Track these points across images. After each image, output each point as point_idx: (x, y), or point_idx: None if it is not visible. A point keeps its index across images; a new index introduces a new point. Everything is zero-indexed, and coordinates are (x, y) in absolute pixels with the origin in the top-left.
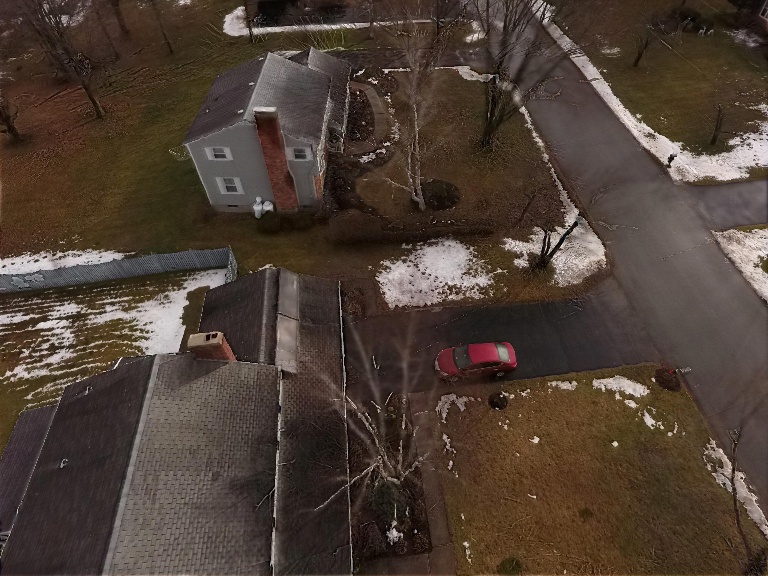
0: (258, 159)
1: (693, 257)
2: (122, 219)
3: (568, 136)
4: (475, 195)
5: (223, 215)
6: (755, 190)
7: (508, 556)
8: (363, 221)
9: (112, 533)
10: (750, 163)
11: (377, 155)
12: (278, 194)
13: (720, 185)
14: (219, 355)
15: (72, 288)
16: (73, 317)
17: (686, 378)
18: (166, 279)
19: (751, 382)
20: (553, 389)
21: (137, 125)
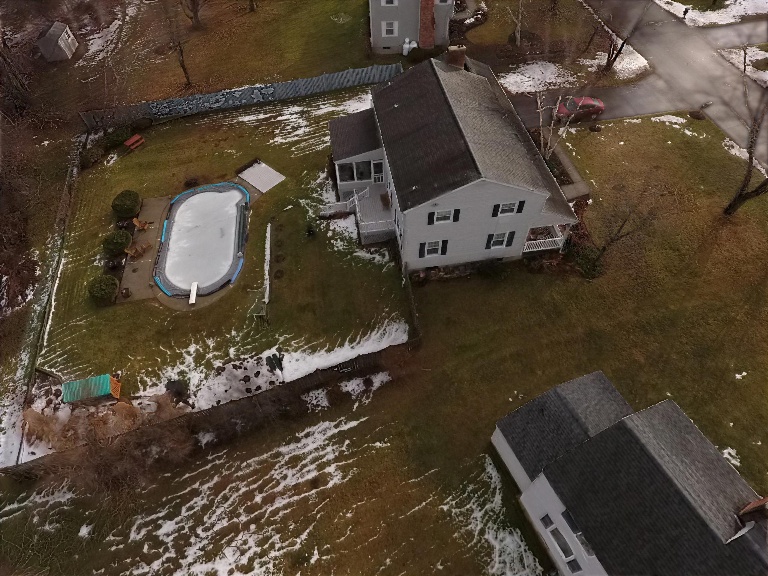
0: (414, 4)
1: (706, 62)
2: (305, 64)
3: (609, 5)
4: (552, 38)
5: (379, 55)
6: (746, 27)
7: (617, 184)
8: (486, 46)
9: (451, 106)
10: (741, 13)
11: (476, 19)
12: (423, 33)
13: (721, 26)
14: (461, 61)
15: (290, 100)
16: (300, 113)
17: (708, 115)
18: (355, 90)
19: (748, 114)
20: (627, 123)
21: (284, 14)
